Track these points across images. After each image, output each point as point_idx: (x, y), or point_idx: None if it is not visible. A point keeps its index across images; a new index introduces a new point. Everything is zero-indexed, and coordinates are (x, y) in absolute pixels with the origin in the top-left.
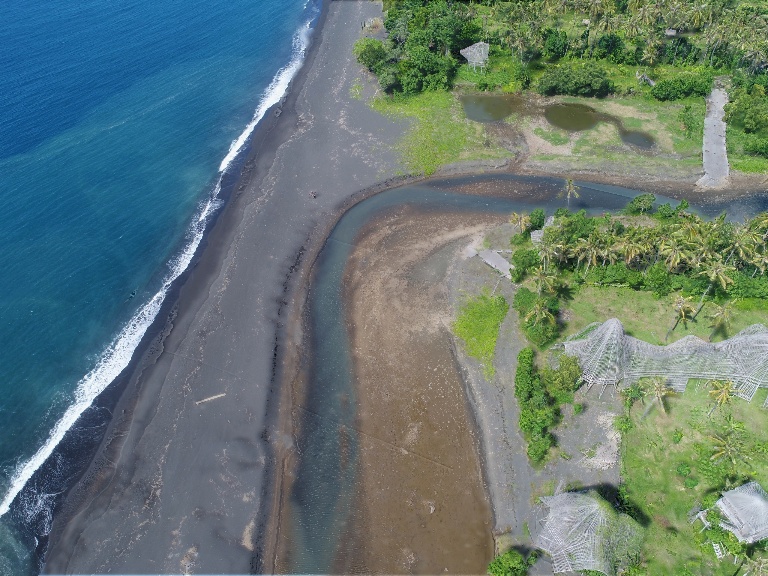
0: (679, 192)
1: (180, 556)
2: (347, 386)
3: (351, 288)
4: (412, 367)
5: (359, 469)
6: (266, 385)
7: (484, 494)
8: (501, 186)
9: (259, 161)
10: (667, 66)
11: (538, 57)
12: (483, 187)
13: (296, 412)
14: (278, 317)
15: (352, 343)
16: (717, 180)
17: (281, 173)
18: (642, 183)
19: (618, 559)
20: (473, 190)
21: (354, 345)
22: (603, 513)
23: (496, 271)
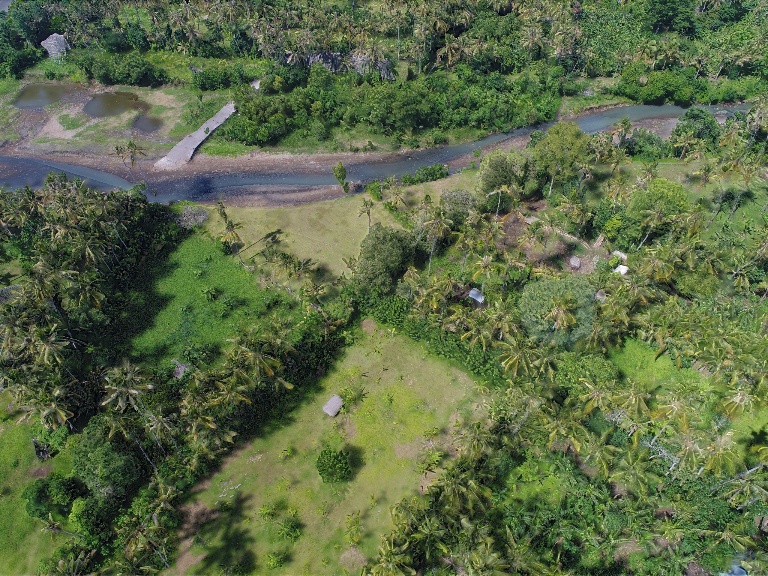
0: (134, 172)
1: None
2: None
3: None
4: None
5: None
6: None
7: None
8: None
9: None
10: (237, 59)
11: (130, 49)
12: None
13: None
14: None
15: None
16: (174, 162)
17: None
18: (108, 164)
19: None
20: None
21: None
22: None
23: None
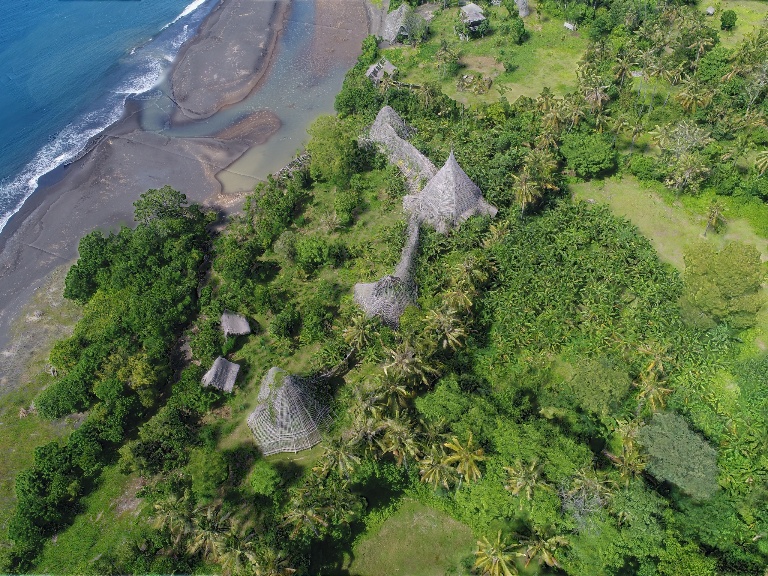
0: None
1: None
2: (310, 14)
3: None
4: (343, 8)
5: (313, 33)
6: (271, 12)
7: None
8: None
9: None
10: None
11: None
12: None
13: (285, 21)
14: None
15: (314, 3)
16: None
17: None
18: None
19: (415, 34)
20: None
21: (315, 4)
22: (405, 5)
23: None
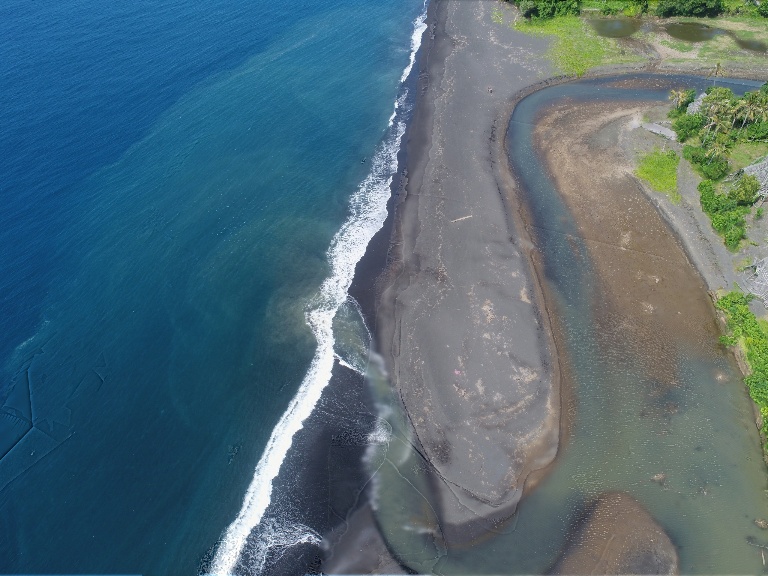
0: None
1: (480, 306)
2: (563, 212)
3: (542, 152)
4: (611, 199)
5: (591, 260)
6: (501, 210)
7: (694, 271)
8: (644, 82)
9: (431, 70)
10: None
11: None
12: (629, 83)
13: (529, 228)
14: (492, 170)
15: (557, 186)
16: None
17: (456, 76)
18: (765, 76)
19: None
20: (621, 85)
21: (559, 187)
22: None
23: (661, 136)
